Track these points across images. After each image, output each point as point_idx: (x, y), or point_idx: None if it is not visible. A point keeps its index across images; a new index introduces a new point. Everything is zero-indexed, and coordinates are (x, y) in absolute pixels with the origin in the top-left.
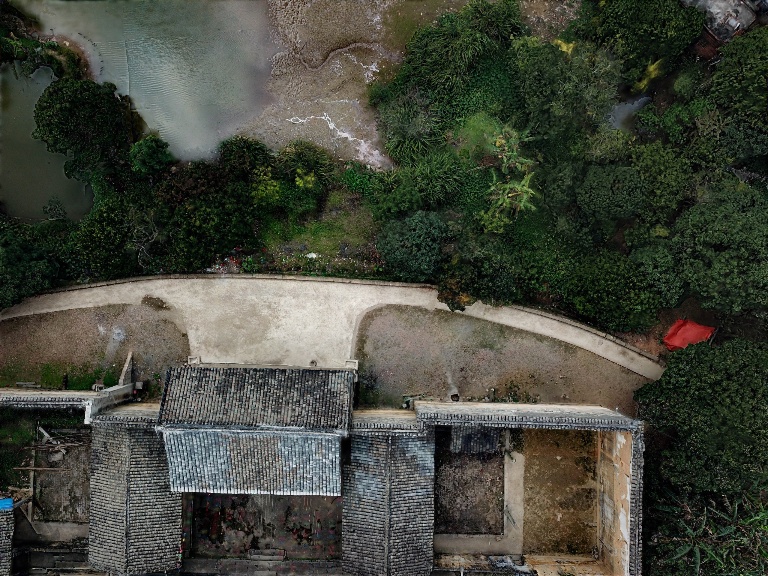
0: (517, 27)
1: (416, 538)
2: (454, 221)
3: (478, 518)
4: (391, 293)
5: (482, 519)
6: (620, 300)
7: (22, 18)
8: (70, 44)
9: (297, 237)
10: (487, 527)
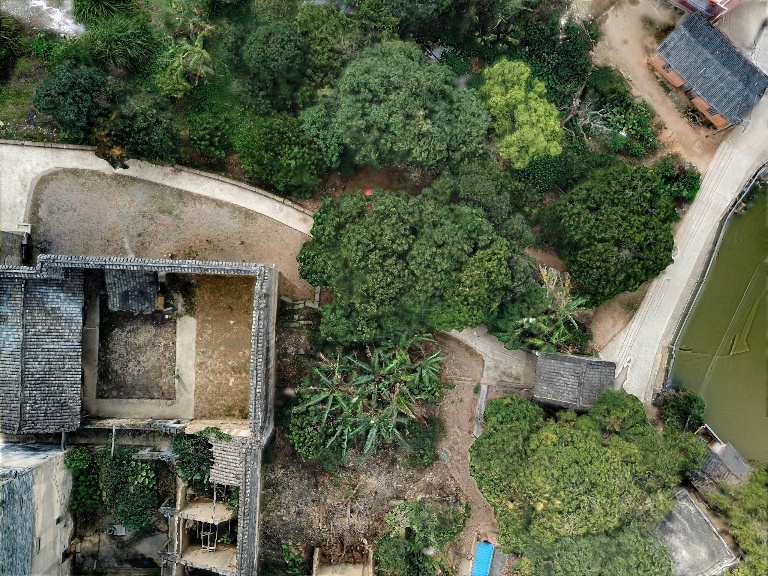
0: None
1: (59, 391)
2: (115, 76)
3: (150, 383)
4: (67, 157)
5: (154, 384)
6: (278, 156)
7: None
8: None
9: None
10: (160, 392)
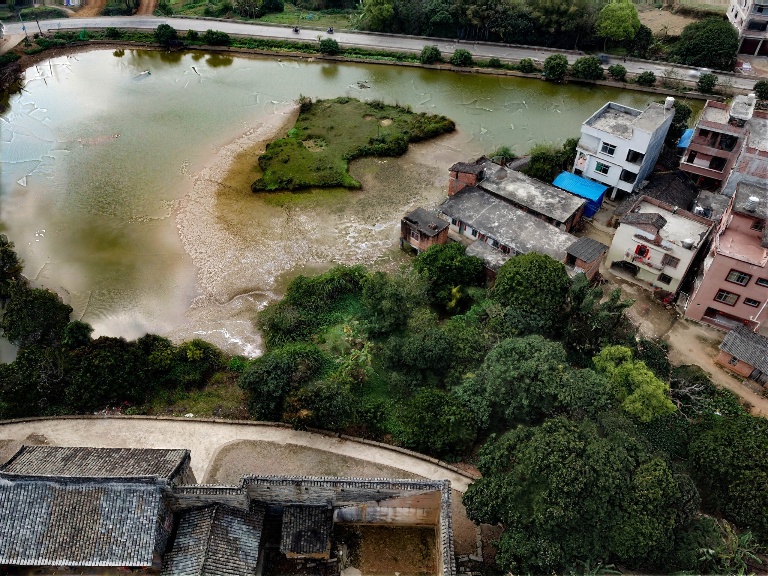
0: (364, 275)
1: None
2: None
3: None
4: (249, 431)
5: None
6: (438, 415)
7: (25, 280)
8: (52, 292)
9: (181, 402)
10: None
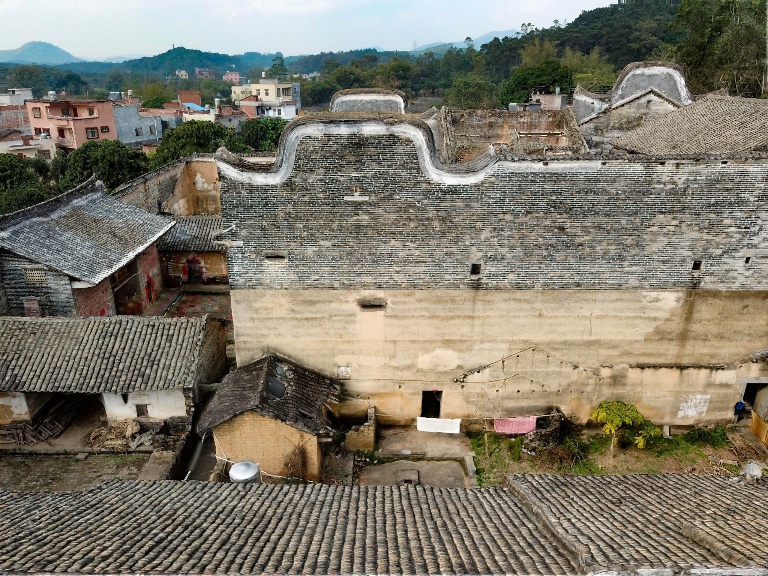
0: None
1: None
2: None
3: None
4: None
5: None
6: None
7: None
8: None
9: None
10: None
